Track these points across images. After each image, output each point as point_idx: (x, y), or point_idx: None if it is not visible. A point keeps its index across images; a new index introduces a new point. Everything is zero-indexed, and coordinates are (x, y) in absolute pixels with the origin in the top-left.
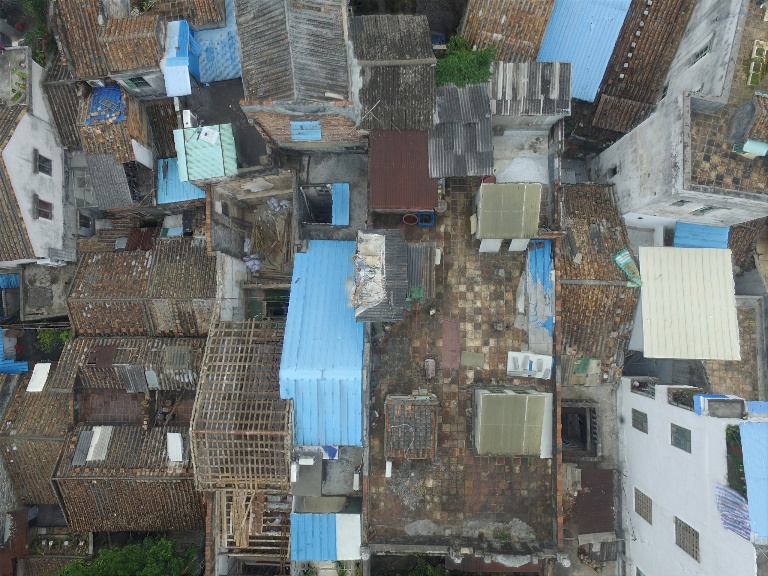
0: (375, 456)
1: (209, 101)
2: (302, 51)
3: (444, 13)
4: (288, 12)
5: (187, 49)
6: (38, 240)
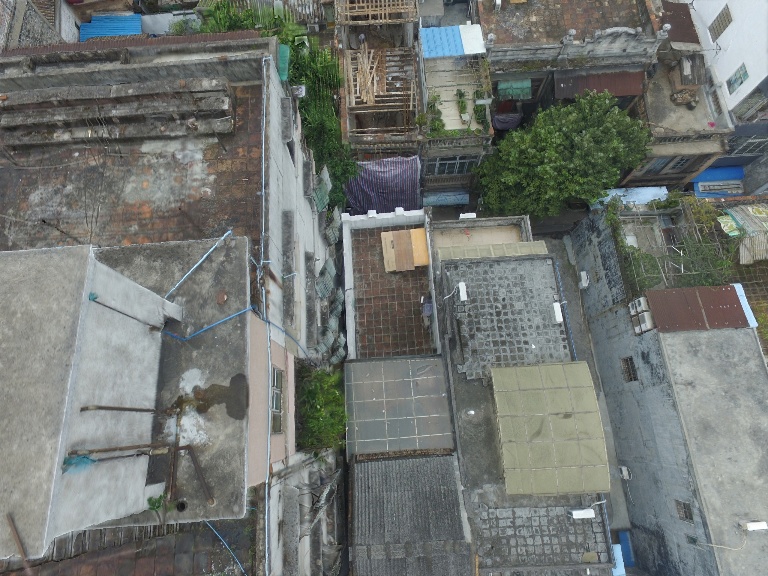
0: (484, 3)
1: None
2: None
3: None
4: None
5: None
6: None
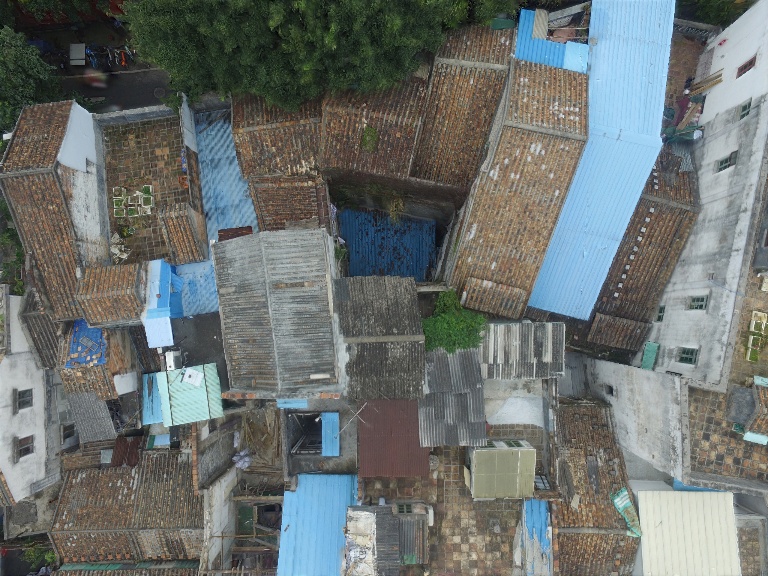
0: None
1: (193, 332)
2: (286, 333)
3: (433, 210)
4: (270, 295)
5: (168, 296)
6: (19, 483)
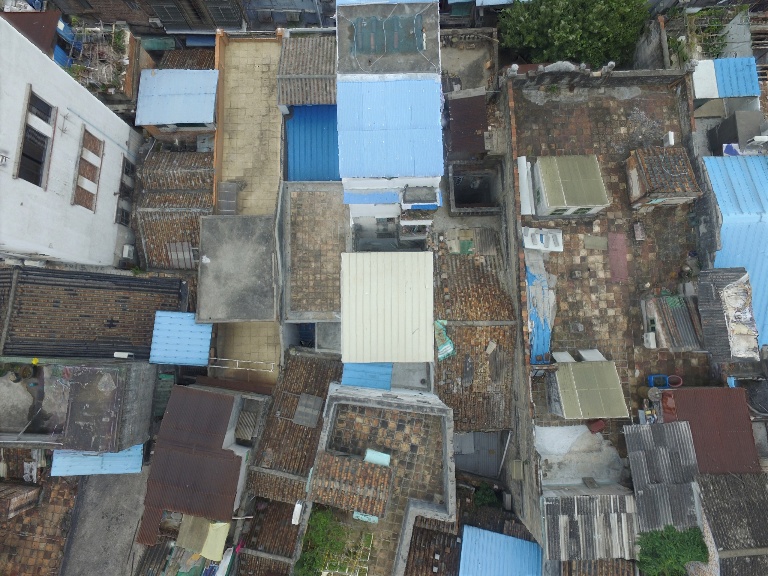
0: None
1: None
2: None
3: None
4: None
5: None
6: None
